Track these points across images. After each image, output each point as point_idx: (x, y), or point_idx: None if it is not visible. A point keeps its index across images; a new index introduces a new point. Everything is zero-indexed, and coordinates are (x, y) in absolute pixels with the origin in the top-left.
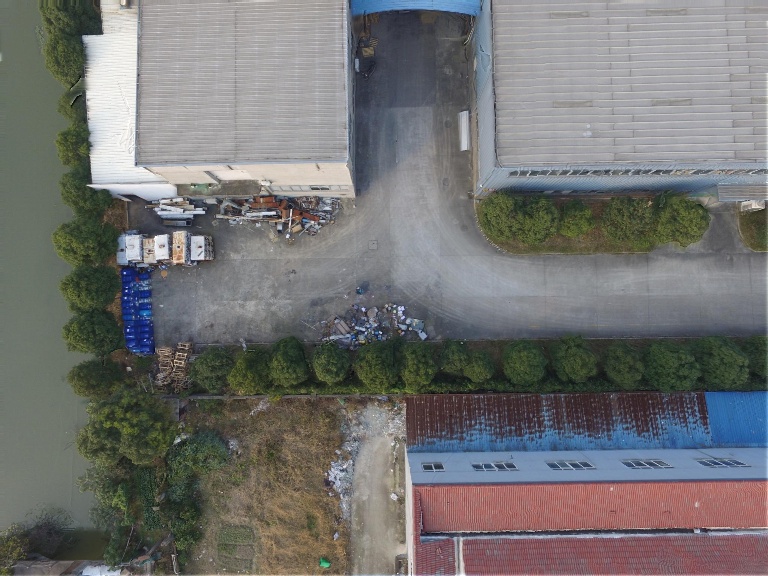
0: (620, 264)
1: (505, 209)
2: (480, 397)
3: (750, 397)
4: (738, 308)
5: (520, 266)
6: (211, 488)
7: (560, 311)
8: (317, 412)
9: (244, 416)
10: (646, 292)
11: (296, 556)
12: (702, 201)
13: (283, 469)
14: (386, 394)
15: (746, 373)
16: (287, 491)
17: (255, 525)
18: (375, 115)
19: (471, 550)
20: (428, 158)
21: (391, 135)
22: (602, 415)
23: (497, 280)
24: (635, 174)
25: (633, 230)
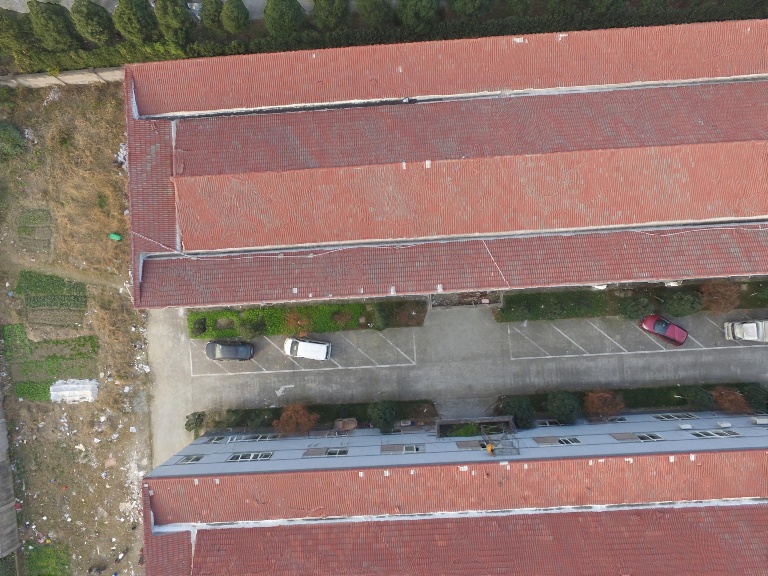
0: None
1: None
2: None
3: None
4: None
5: None
6: (10, 176)
7: None
8: (106, 98)
9: (38, 107)
10: None
11: (90, 233)
12: None
13: (74, 152)
14: None
15: None
16: (79, 172)
17: (52, 208)
18: None
19: (185, 126)
20: None
21: None
22: None
23: None
24: None
25: None
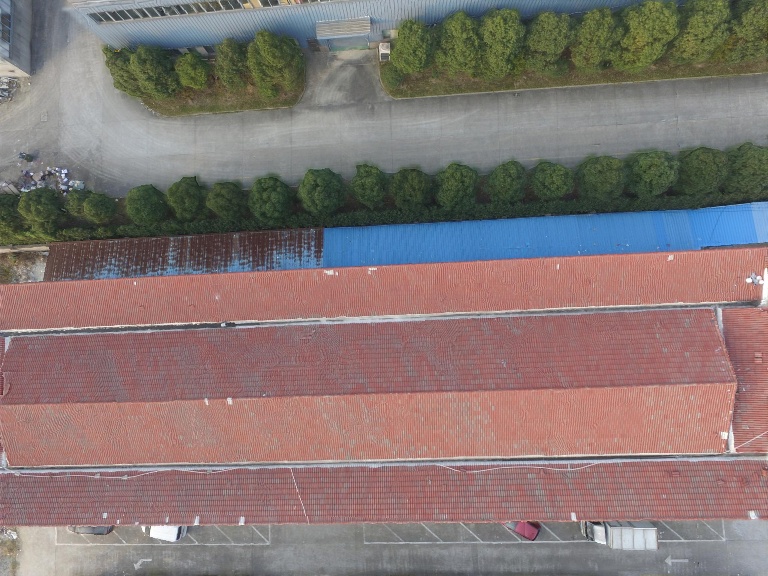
0: (265, 119)
1: (106, 56)
2: (115, 242)
3: (367, 231)
4: (378, 154)
5: (173, 127)
6: None
7: (208, 166)
8: None
9: None
10: (289, 144)
11: None
12: (344, 55)
13: None
14: (36, 244)
15: (317, 191)
16: None
17: None
18: (51, 2)
19: (15, 345)
20: (95, 36)
21: (64, 18)
22: (222, 253)
23: (152, 141)
24: (212, 11)
25: (226, 68)
